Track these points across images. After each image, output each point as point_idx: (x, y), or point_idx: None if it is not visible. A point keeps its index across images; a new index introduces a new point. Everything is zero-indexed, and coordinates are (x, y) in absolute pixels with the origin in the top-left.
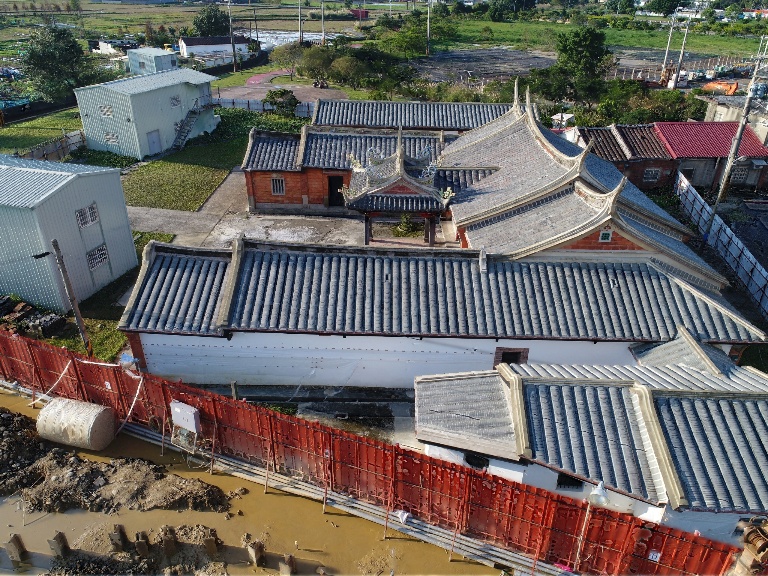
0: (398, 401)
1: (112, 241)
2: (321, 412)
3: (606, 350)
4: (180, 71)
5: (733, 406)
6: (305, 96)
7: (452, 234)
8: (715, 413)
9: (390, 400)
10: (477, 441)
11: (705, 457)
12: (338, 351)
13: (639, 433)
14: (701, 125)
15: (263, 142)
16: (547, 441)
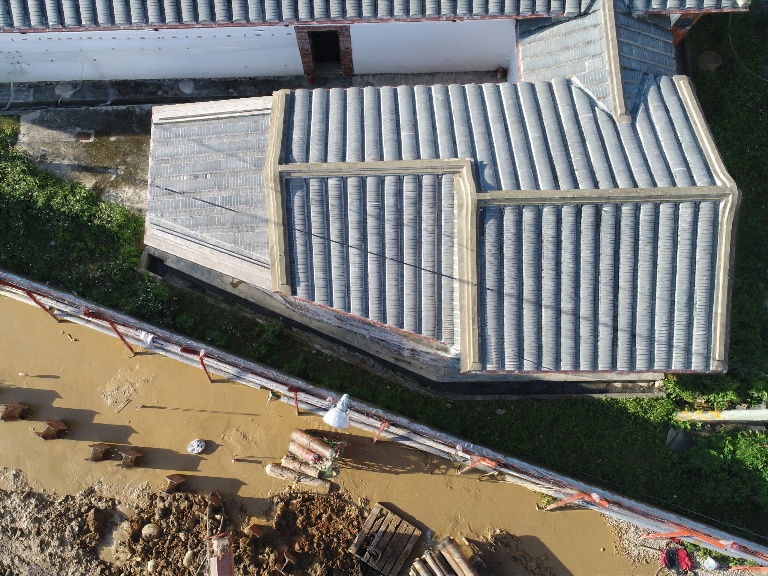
0: (170, 99)
1: None
2: (54, 131)
3: (477, 21)
4: None
5: (601, 214)
6: None
7: None
8: (567, 230)
9: (157, 98)
10: (223, 259)
11: (527, 302)
12: (35, 42)
13: (452, 251)
14: None
15: None
16: (314, 271)
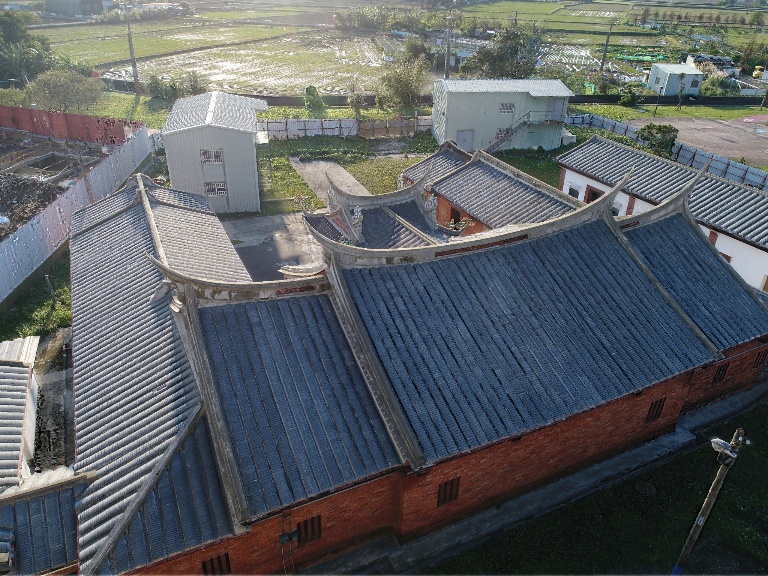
0: None
1: (235, 183)
2: None
3: None
4: (545, 82)
5: None
6: (763, 147)
7: None
8: None
9: None
10: None
11: None
12: None
13: None
14: None
15: (445, 156)
16: None
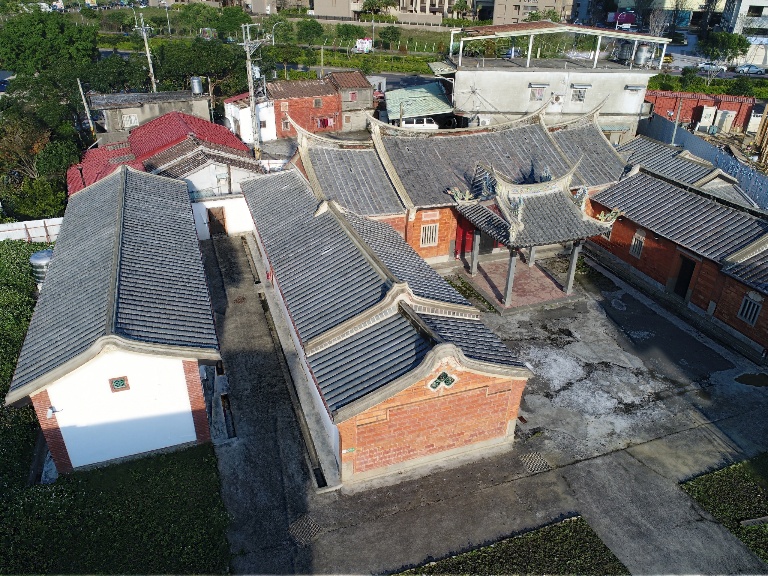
0: None
1: None
2: None
3: None
4: None
5: None
6: None
7: (444, 264)
8: None
9: None
10: None
11: None
12: None
13: None
14: (187, 123)
15: None
16: None
